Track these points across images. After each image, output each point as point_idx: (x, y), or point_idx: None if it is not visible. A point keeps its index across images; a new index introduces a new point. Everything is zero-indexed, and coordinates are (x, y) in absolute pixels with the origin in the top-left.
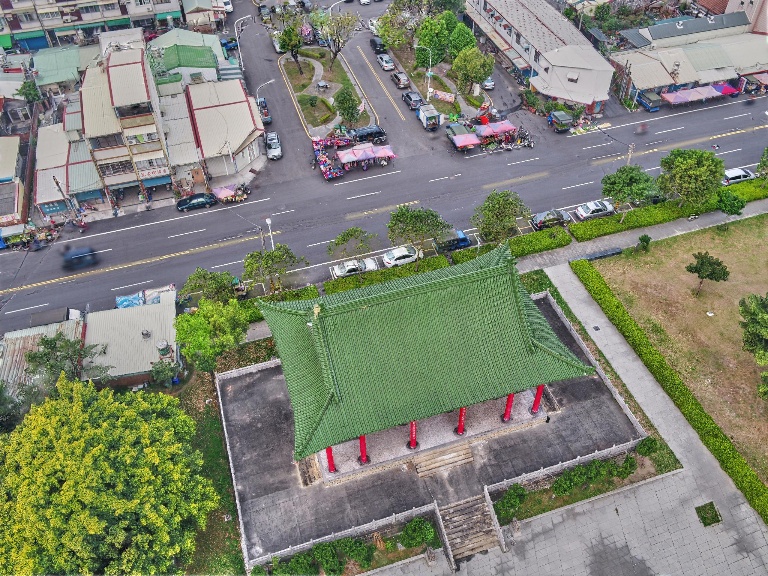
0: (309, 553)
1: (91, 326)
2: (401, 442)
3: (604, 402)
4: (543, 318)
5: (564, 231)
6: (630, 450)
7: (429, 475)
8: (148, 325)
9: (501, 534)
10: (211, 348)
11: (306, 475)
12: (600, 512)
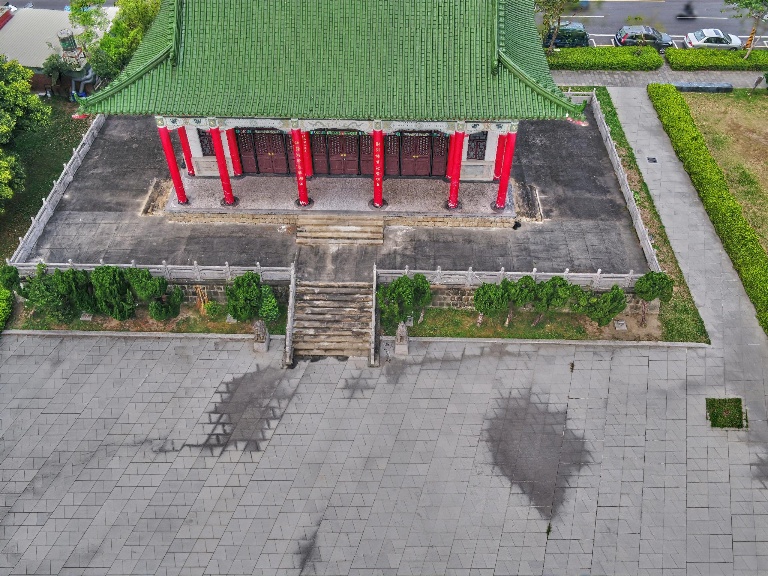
0: (89, 274)
1: (16, 18)
2: (291, 195)
3: (615, 227)
4: (542, 56)
5: (656, 52)
6: (627, 290)
7: (310, 244)
8: (76, 29)
9: (372, 336)
10: (117, 49)
11: (152, 203)
12: (544, 360)
